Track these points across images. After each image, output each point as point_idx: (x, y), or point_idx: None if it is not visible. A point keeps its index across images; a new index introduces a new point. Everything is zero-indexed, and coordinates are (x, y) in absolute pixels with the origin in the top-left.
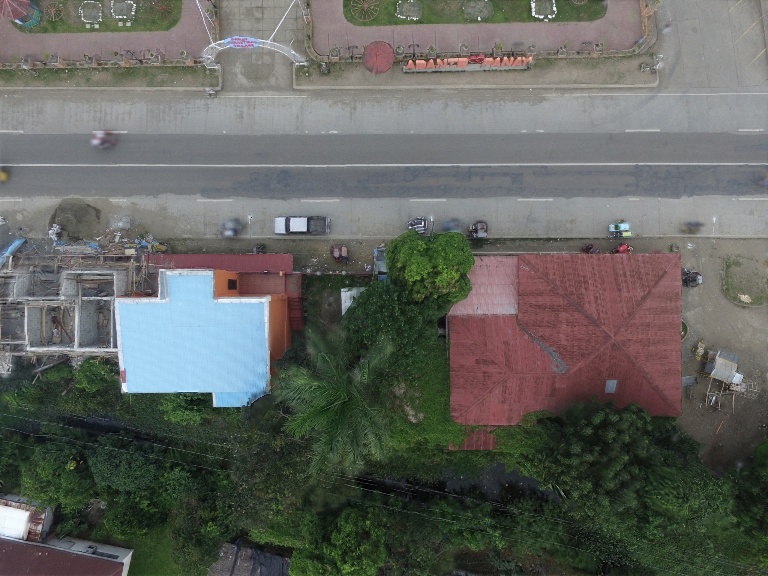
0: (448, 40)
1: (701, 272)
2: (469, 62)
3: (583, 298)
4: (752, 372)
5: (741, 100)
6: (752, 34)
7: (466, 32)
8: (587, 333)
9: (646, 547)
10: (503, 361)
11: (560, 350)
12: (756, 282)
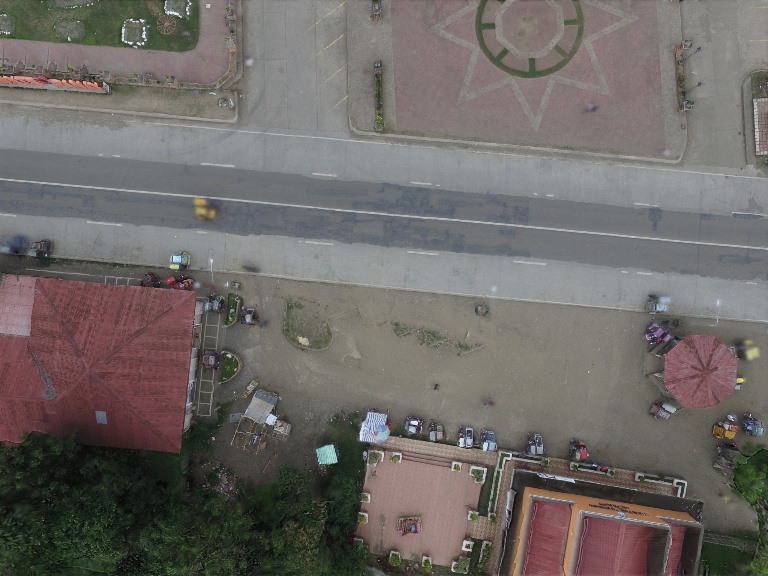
0: (38, 57)
1: (264, 311)
2: (38, 81)
3: (77, 327)
4: (305, 414)
5: (317, 144)
6: (336, 80)
7: (56, 51)
8: (72, 362)
9: None
10: None
11: (52, 376)
12: (316, 326)
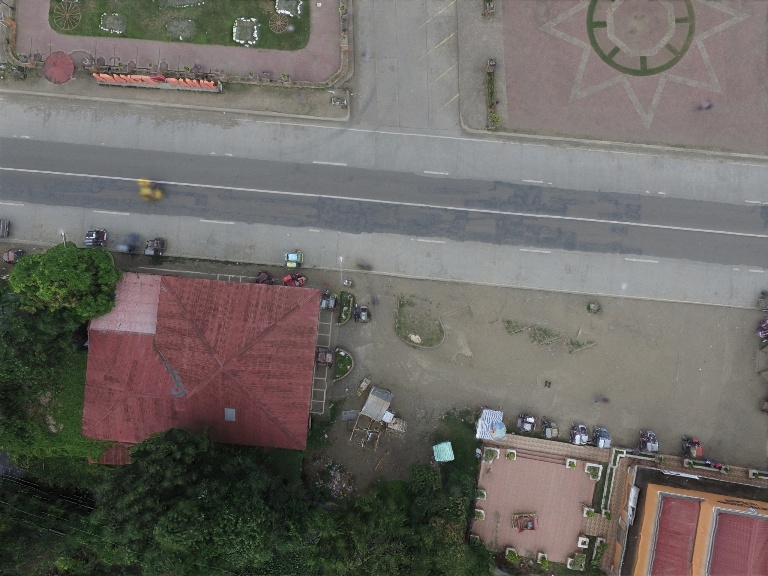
0: (149, 56)
1: (376, 308)
2: (154, 80)
3: (207, 325)
4: (417, 412)
5: (429, 142)
6: (447, 78)
7: (167, 50)
8: (203, 360)
9: (306, 575)
10: (126, 380)
11: (182, 374)
12: (428, 323)
